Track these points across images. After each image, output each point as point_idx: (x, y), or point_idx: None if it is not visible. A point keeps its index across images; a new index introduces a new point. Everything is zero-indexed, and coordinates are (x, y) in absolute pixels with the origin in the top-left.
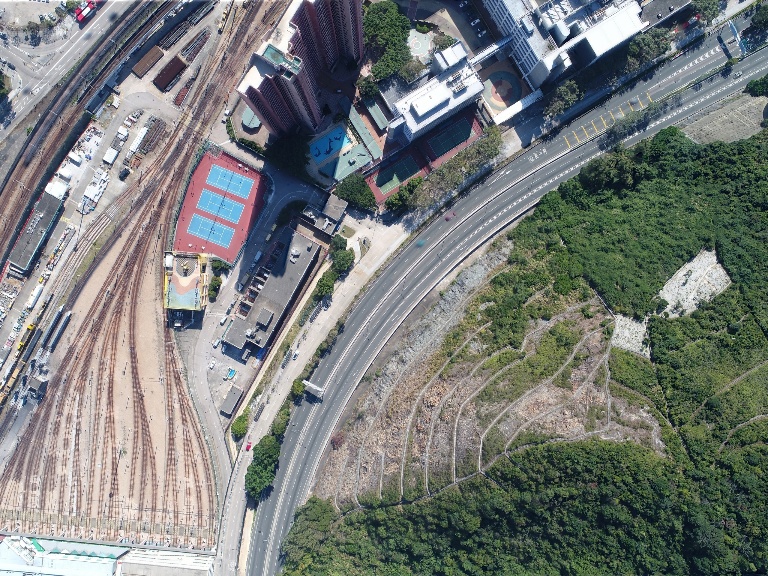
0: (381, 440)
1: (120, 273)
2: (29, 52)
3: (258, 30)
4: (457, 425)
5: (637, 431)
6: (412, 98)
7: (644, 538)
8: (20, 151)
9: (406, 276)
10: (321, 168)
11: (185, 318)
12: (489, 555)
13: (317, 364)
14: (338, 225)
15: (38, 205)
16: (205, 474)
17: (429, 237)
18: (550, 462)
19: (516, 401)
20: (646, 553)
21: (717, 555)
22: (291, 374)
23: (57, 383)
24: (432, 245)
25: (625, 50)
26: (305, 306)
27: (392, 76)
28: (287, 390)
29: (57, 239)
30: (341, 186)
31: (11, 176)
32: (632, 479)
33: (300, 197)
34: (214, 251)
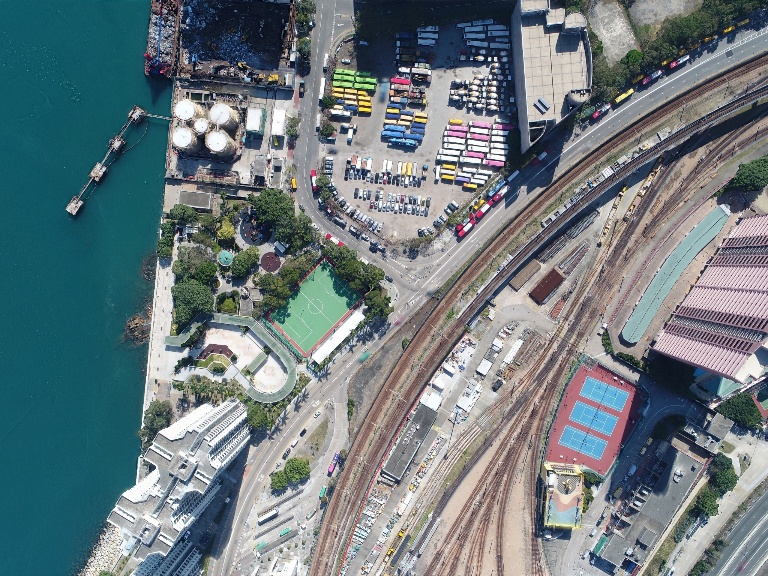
0: None
1: (489, 482)
2: (406, 265)
3: (638, 243)
4: None
5: None
6: None
7: None
8: (396, 362)
9: None
10: (704, 385)
11: (557, 530)
12: None
13: None
14: None
15: (414, 416)
16: None
17: None
18: None
19: None
20: None
21: None
22: None
23: None
24: None
25: None
26: (679, 521)
27: None
28: None
29: (428, 447)
30: (728, 405)
31: (384, 385)
32: None
33: (677, 411)
34: (585, 463)
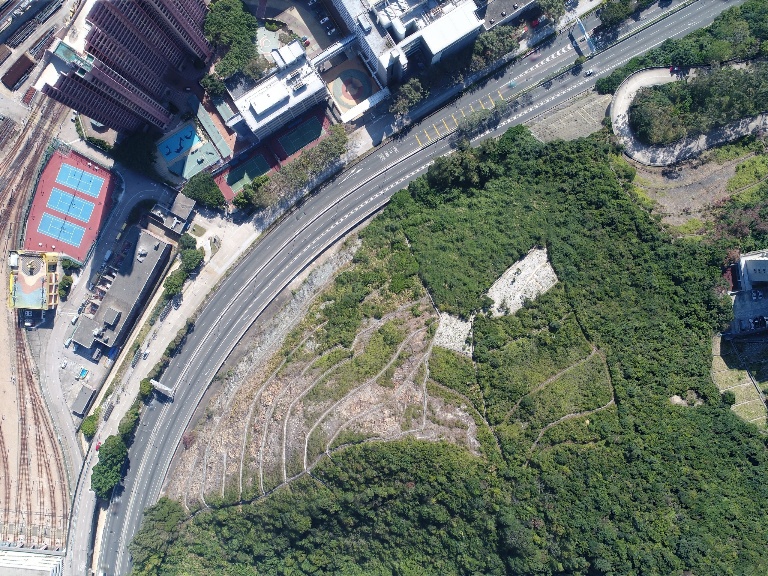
0: (224, 440)
1: None
2: None
3: None
4: (286, 424)
5: (452, 430)
6: (252, 96)
7: (462, 538)
8: None
9: (257, 275)
10: (169, 167)
11: (35, 317)
12: (327, 555)
13: (167, 363)
14: (188, 224)
15: None
16: (58, 474)
17: (280, 236)
18: (367, 461)
19: (340, 400)
20: (466, 553)
21: (526, 555)
22: (142, 374)
23: None
24: (283, 244)
25: (470, 48)
26: (156, 305)
27: (239, 74)
28: (137, 390)
29: None
30: (188, 185)
31: None
32: (446, 478)
33: (150, 196)
34: (65, 250)
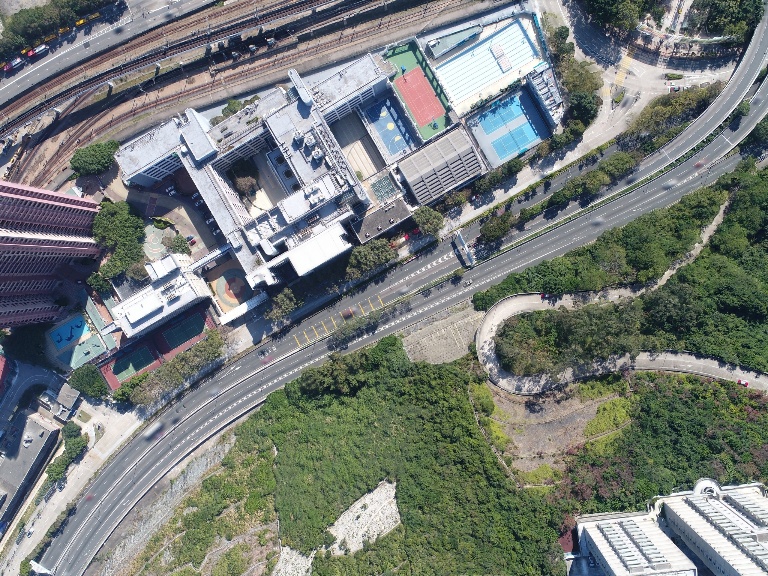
0: None
1: None
2: None
3: None
4: None
5: None
6: (128, 304)
7: None
8: None
9: (137, 463)
10: (58, 356)
11: None
12: None
13: (50, 543)
14: (74, 411)
15: None
16: None
17: (160, 427)
18: None
19: None
20: None
21: None
22: (26, 550)
23: None
24: (163, 435)
25: (346, 259)
26: (43, 485)
27: None
28: None
29: None
30: (74, 376)
31: None
32: None
33: (41, 381)
34: None
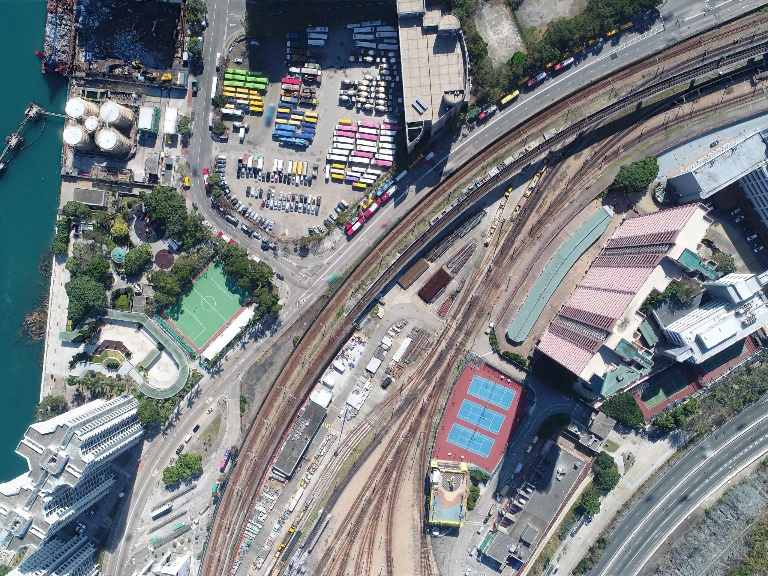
0: None
1: (379, 479)
2: (297, 263)
3: (524, 243)
4: None
5: None
6: (698, 328)
7: None
8: (287, 359)
9: (671, 493)
10: (588, 384)
11: (444, 527)
12: None
13: None
14: (602, 440)
15: (304, 413)
16: None
17: (697, 455)
18: None
19: None
20: None
21: None
22: None
23: None
24: (700, 463)
25: None
26: (565, 519)
27: None
28: None
29: (318, 444)
30: (610, 404)
31: (276, 382)
32: None
33: (563, 410)
34: (473, 460)
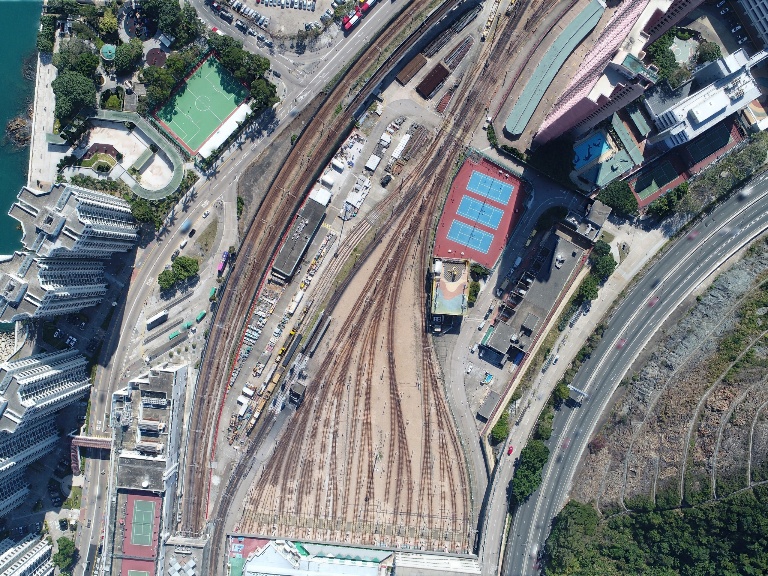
0: (654, 444)
1: (380, 279)
2: (294, 60)
3: (520, 37)
4: (753, 429)
5: None
6: (689, 105)
7: None
8: (285, 158)
9: (665, 281)
10: (584, 174)
11: (446, 323)
12: None
13: None
14: (599, 231)
15: (303, 211)
16: (460, 478)
17: (688, 242)
18: None
19: None
20: None
21: None
22: (551, 379)
23: (315, 388)
24: (691, 250)
25: None
26: (563, 311)
27: None
28: (547, 394)
29: (318, 245)
30: (606, 192)
31: (274, 183)
32: None
33: (560, 203)
34: (473, 257)
